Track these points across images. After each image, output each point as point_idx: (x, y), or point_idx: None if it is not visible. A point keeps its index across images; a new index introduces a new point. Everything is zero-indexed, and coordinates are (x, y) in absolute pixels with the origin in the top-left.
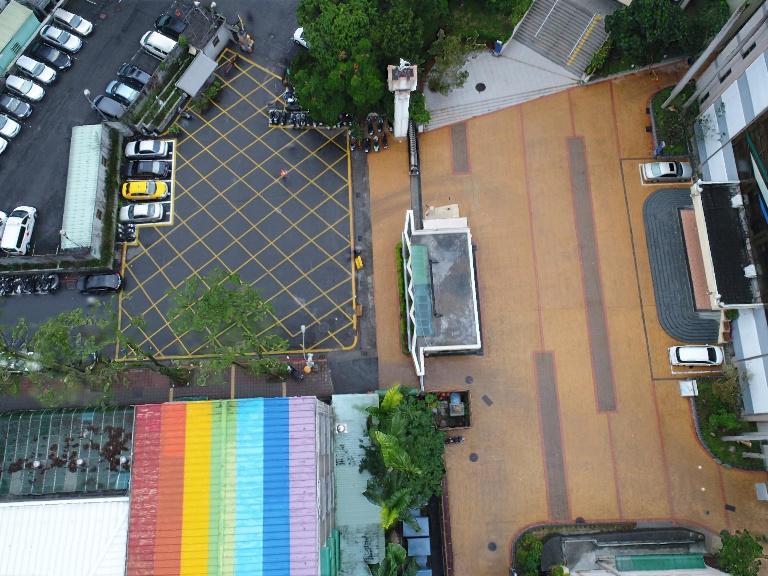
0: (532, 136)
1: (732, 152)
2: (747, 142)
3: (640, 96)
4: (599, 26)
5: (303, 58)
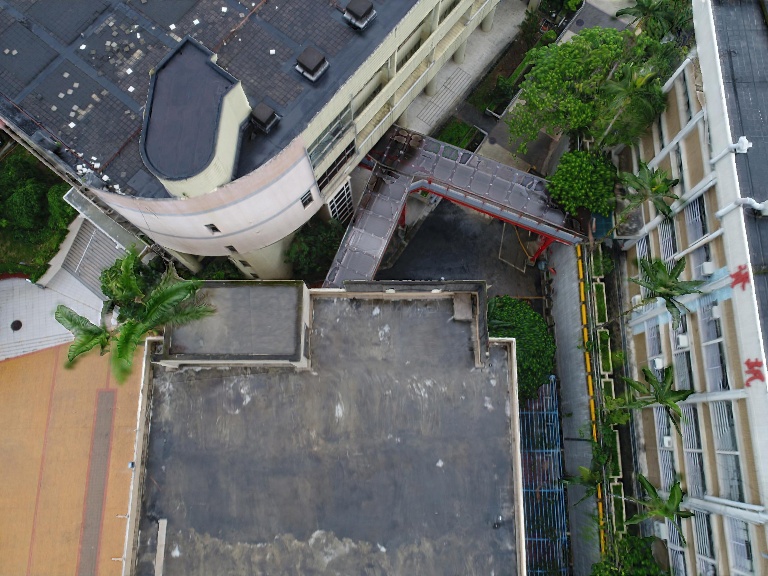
0: (62, 386)
1: None
2: None
3: None
4: None
5: None
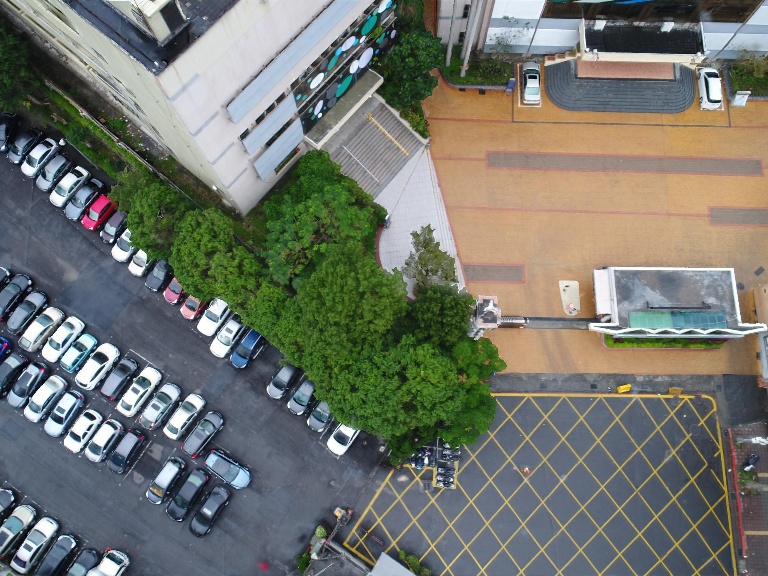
0: (484, 200)
1: (552, 20)
2: (561, 3)
3: (446, 94)
4: (378, 117)
5: (400, 438)
